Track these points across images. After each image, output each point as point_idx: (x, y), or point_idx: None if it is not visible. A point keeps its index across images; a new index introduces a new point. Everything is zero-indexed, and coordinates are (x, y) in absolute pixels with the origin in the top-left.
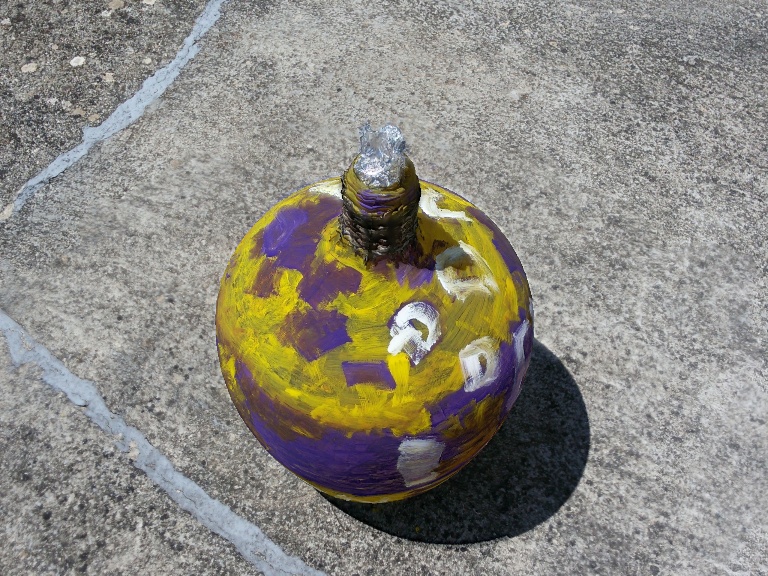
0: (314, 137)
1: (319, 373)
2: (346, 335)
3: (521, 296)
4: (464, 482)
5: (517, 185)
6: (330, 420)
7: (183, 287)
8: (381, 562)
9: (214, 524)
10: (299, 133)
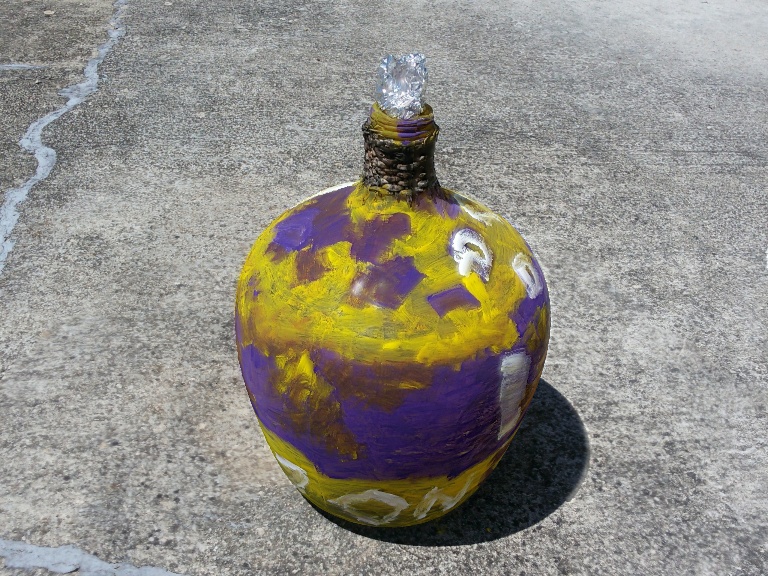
0: (177, 276)
1: (409, 317)
2: (419, 274)
3: None
4: (500, 477)
5: None
6: (437, 358)
7: (121, 428)
8: (477, 570)
9: None
10: (160, 276)
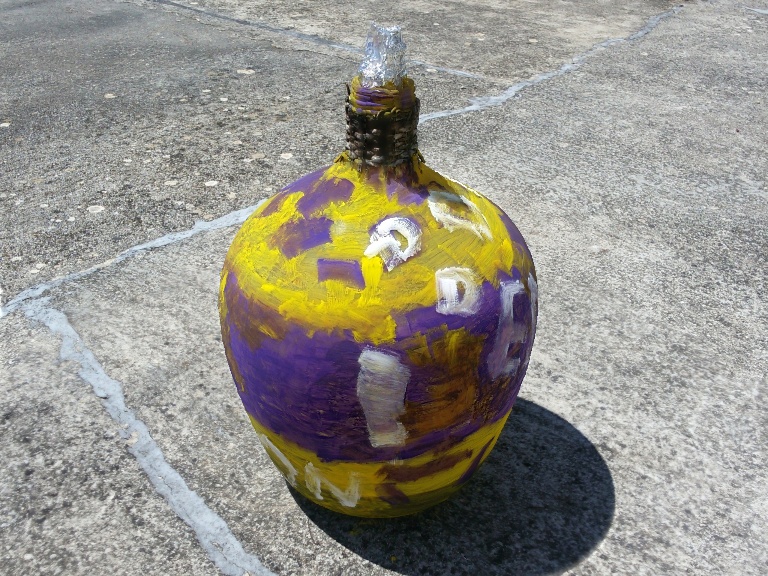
0: None
1: (295, 271)
2: (328, 237)
3: (518, 261)
4: (458, 528)
5: (582, 309)
6: (295, 316)
7: None
8: None
9: (183, 510)
10: None
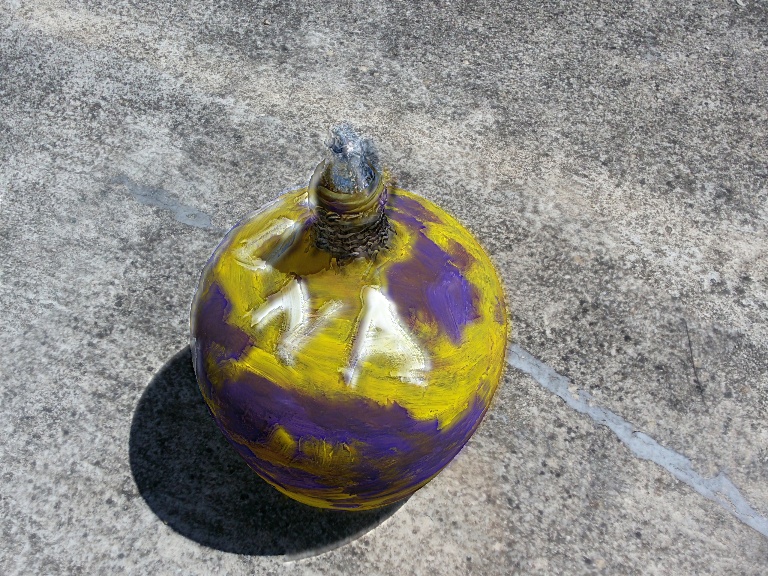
0: None
1: None
2: None
3: None
4: None
5: None
6: None
7: None
8: None
9: None
10: None
